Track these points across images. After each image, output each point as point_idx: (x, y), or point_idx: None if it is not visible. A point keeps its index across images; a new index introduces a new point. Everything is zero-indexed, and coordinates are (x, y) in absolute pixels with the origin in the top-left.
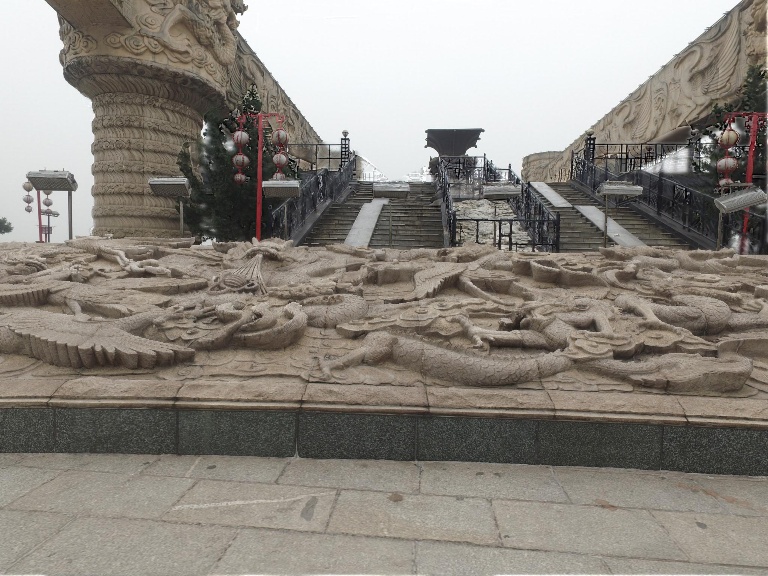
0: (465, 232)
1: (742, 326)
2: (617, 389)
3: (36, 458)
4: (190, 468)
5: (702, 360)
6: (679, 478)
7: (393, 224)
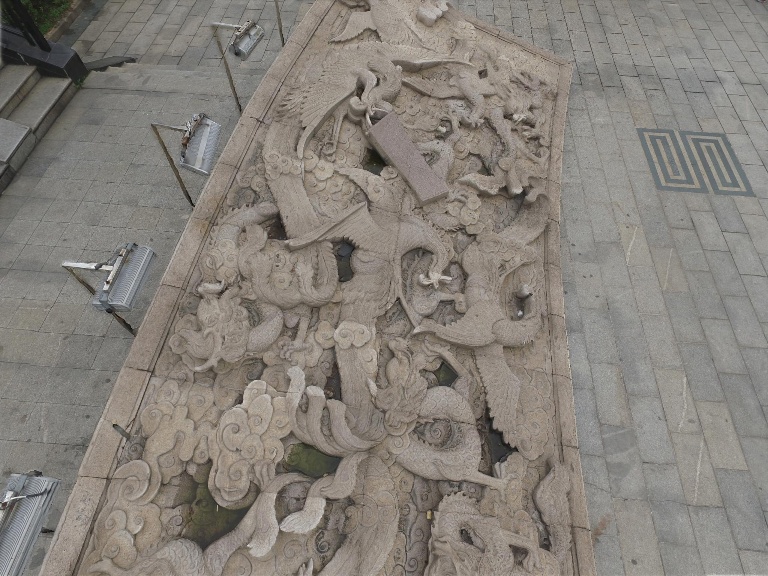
0: None
1: None
2: None
3: None
4: None
5: (549, 486)
6: None
7: None
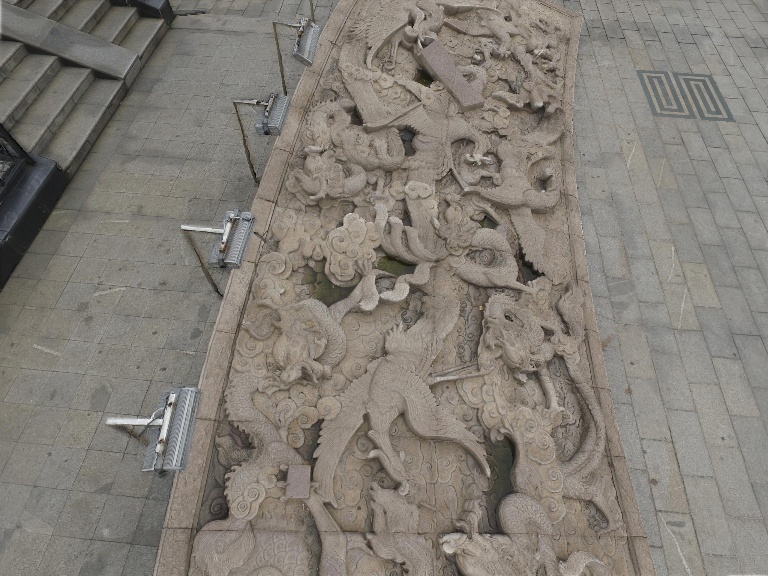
0: None
1: None
2: None
3: None
4: None
5: (569, 299)
6: None
7: None
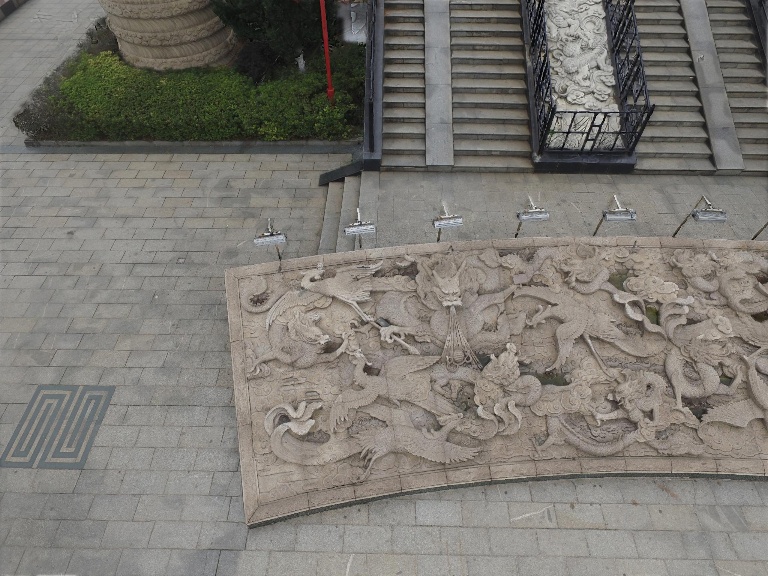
0: (550, 66)
1: (719, 394)
2: (651, 455)
3: (444, 494)
4: (500, 495)
5: (689, 441)
6: (660, 481)
7: (468, 30)
